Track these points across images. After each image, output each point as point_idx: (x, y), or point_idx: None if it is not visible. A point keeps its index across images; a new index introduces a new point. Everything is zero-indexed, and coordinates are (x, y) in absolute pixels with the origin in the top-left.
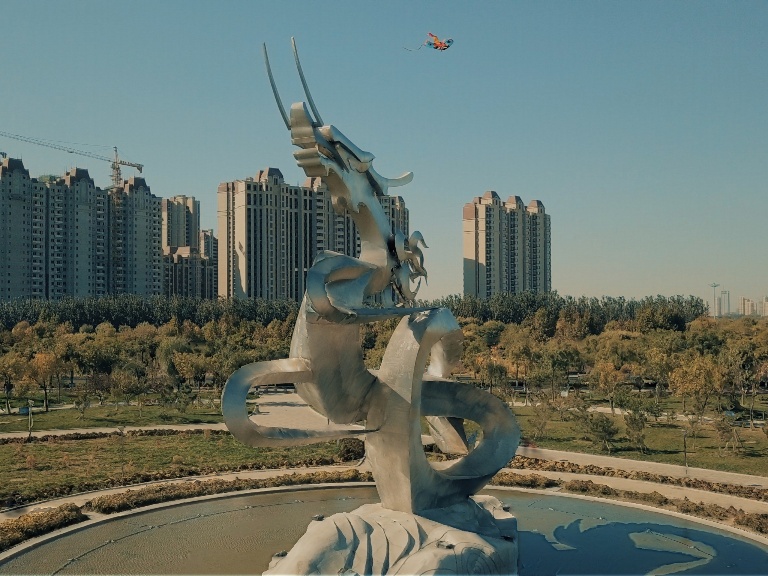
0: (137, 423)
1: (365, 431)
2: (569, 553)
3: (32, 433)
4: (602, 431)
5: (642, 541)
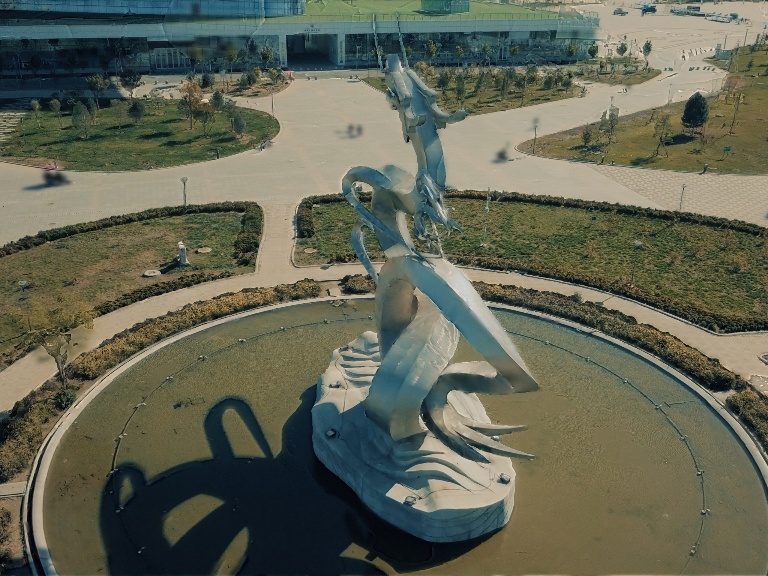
0: None
1: None
2: None
3: None
4: None
5: None
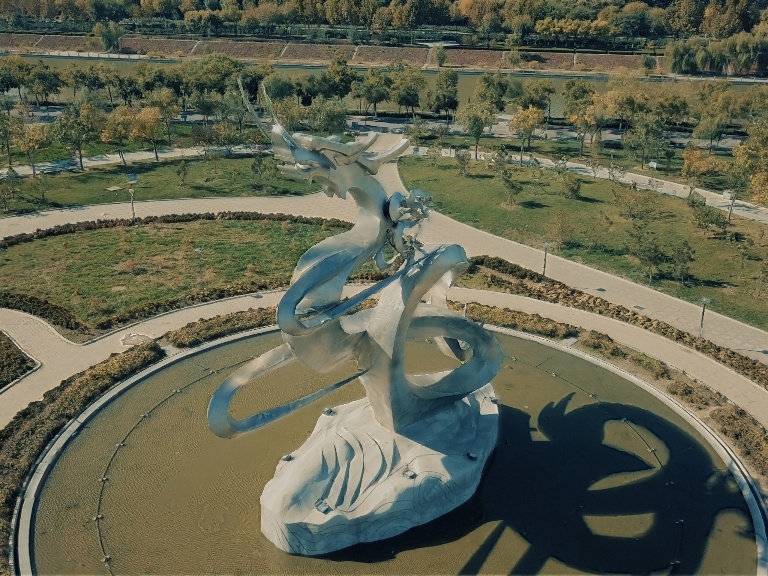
0: (231, 193)
1: (352, 378)
2: (541, 445)
3: (139, 205)
4: (648, 260)
5: (611, 435)
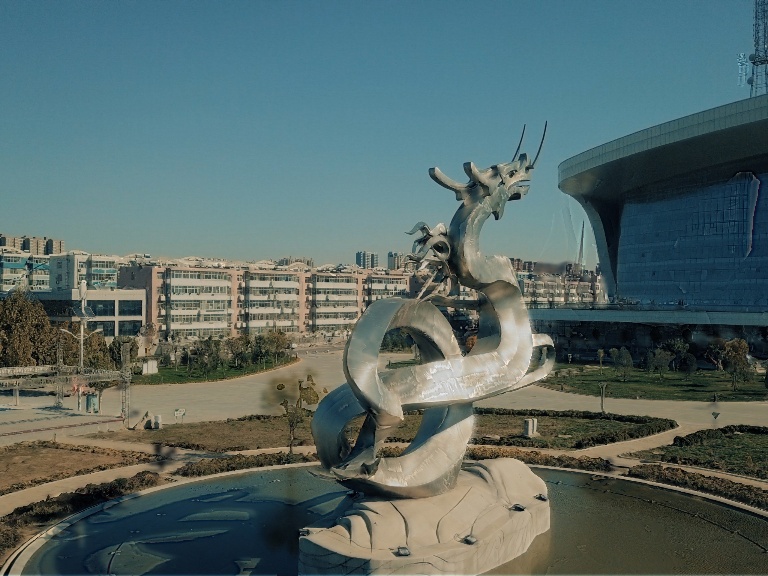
0: None
1: None
2: None
3: None
4: None
5: (148, 565)
